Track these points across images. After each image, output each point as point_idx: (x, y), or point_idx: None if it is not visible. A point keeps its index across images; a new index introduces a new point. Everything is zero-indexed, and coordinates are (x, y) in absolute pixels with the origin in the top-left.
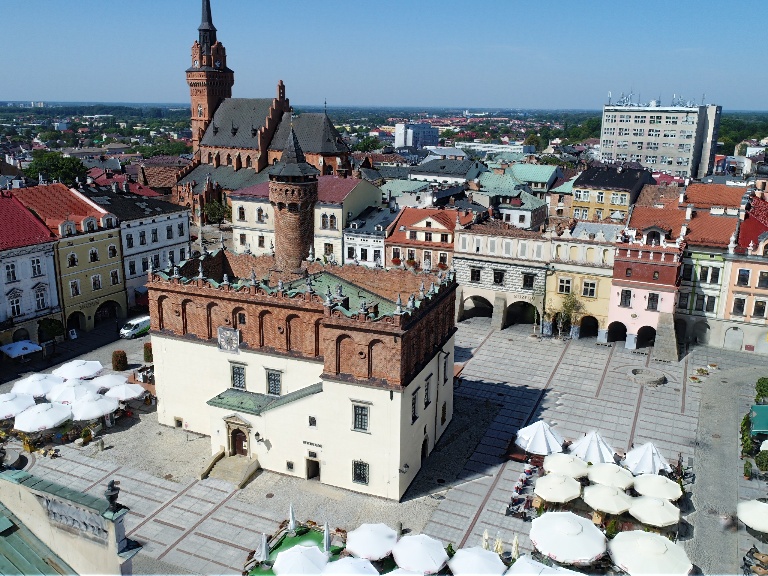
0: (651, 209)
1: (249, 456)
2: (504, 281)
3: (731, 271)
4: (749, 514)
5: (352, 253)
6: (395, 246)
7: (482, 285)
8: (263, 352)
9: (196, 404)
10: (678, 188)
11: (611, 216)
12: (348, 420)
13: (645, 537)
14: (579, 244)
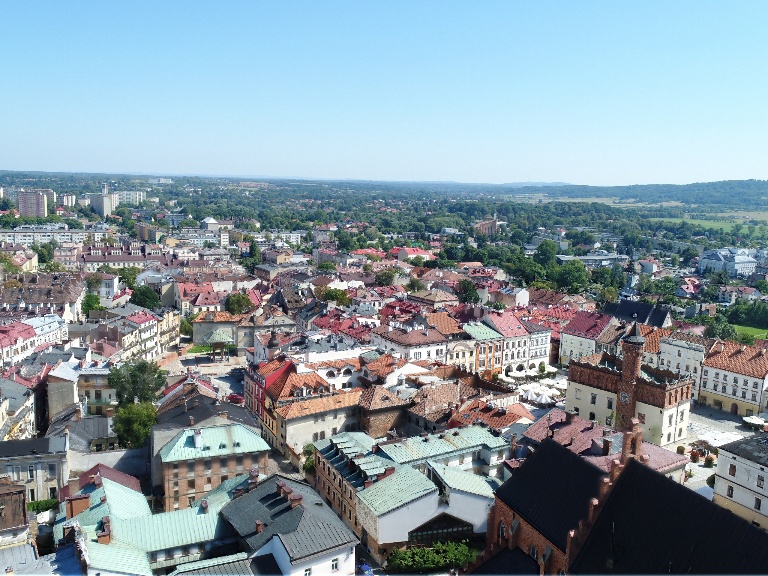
0: None
1: None
2: None
3: None
4: (514, 380)
5: None
6: None
7: None
8: None
9: None
10: None
11: None
12: None
13: (549, 379)
14: None
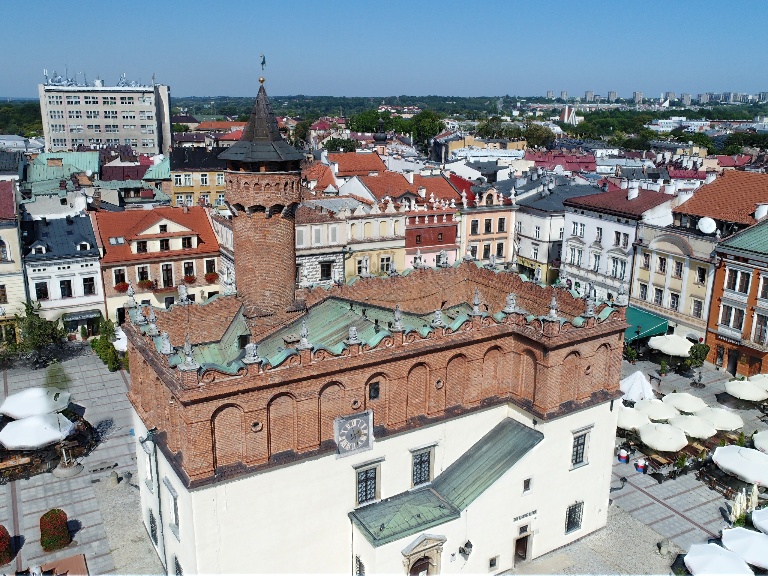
0: (373, 178)
1: None
2: (300, 277)
3: (467, 223)
4: (746, 392)
5: (43, 291)
6: (117, 267)
7: None
8: (415, 428)
9: (288, 569)
10: None
11: (327, 191)
12: (567, 460)
13: None
14: (373, 219)
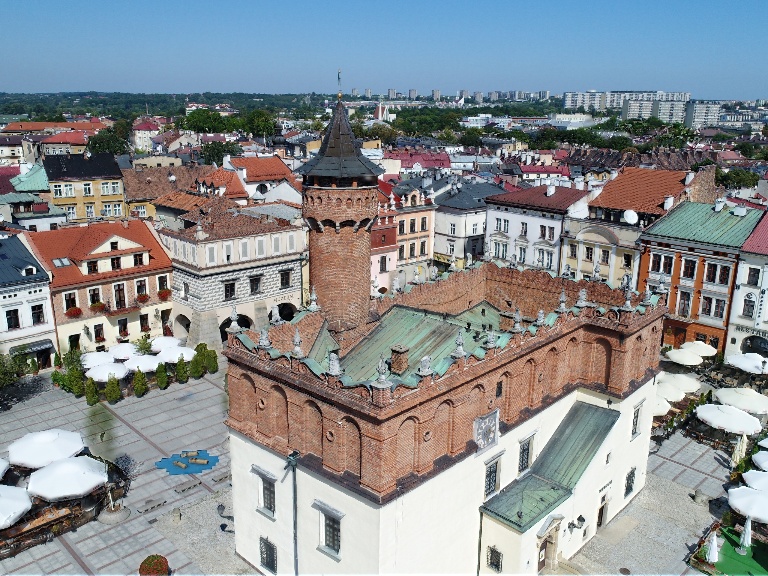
0: None
1: (557, 562)
2: (262, 287)
3: None
4: (688, 358)
5: None
6: (67, 291)
7: (239, 300)
8: None
9: (438, 570)
10: (155, 169)
11: (255, 197)
12: None
13: (742, 390)
14: None
